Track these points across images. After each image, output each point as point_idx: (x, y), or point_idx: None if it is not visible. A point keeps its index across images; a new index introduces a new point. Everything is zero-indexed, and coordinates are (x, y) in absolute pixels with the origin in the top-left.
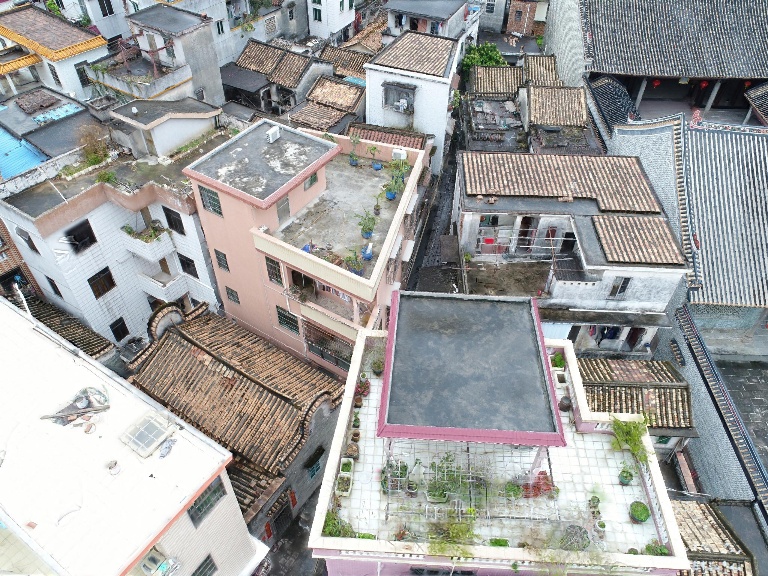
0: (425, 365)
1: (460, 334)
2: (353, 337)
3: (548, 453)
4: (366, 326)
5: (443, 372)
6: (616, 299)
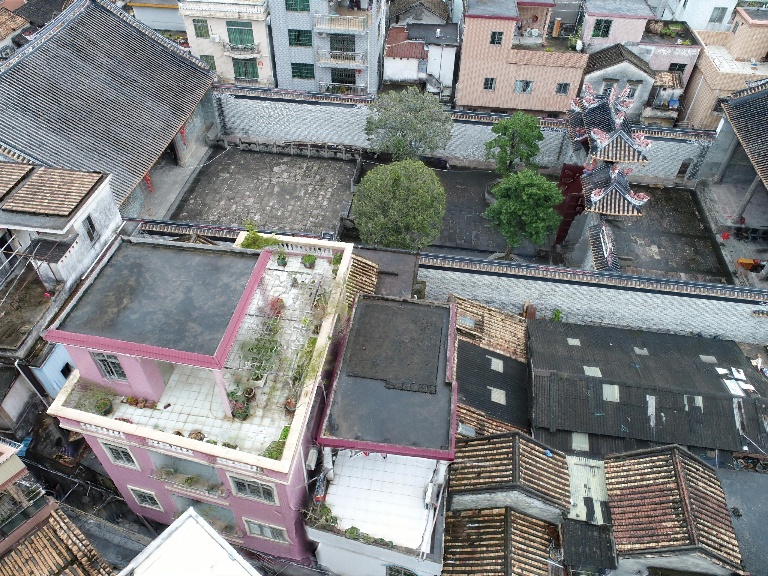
0: (157, 324)
1: (133, 294)
2: (1, 479)
3: (270, 269)
4: (2, 452)
5: (171, 312)
6: (96, 240)
